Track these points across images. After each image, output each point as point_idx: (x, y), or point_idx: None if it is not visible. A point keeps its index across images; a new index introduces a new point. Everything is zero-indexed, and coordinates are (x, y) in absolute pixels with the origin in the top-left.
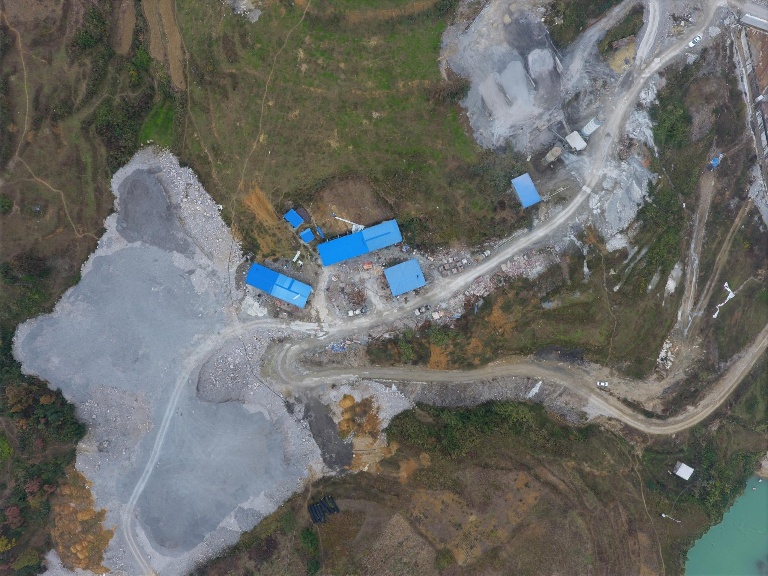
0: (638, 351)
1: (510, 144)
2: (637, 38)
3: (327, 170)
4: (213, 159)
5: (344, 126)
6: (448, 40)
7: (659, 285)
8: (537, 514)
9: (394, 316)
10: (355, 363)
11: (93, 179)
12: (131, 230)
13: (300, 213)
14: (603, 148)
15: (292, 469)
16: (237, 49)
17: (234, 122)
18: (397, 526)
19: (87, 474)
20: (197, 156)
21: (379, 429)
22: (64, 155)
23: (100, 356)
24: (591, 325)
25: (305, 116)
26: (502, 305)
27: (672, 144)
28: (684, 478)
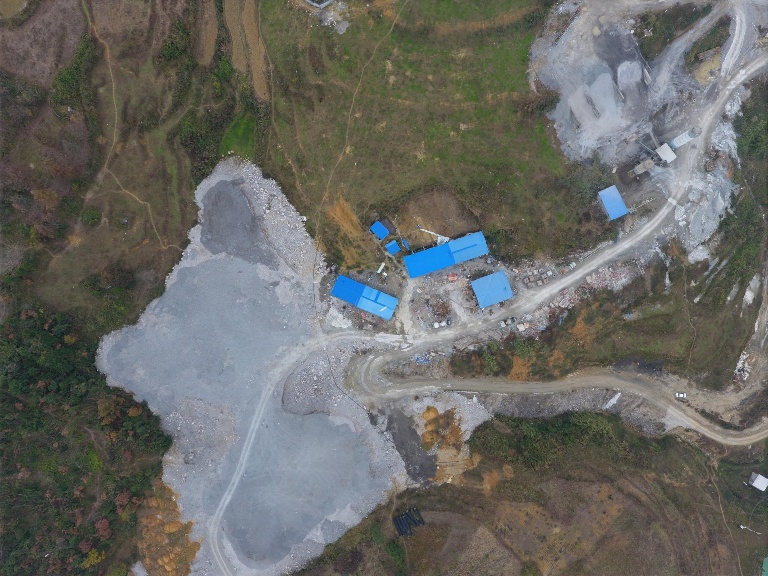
0: (716, 362)
1: (597, 156)
2: (722, 50)
3: (413, 182)
4: (297, 170)
5: (431, 138)
6: (538, 52)
7: (738, 296)
8: (621, 526)
9: (479, 328)
10: (438, 375)
11: (178, 191)
12: (215, 242)
13: (384, 225)
14: (689, 160)
15: (377, 481)
16: (324, 61)
17: (320, 134)
18: (482, 538)
19: (173, 486)
20: (281, 167)
21: (462, 441)
22: (151, 167)
23: (185, 368)
24: (671, 336)
25: (392, 128)
26: (585, 317)
27: (755, 155)
28: (760, 489)
